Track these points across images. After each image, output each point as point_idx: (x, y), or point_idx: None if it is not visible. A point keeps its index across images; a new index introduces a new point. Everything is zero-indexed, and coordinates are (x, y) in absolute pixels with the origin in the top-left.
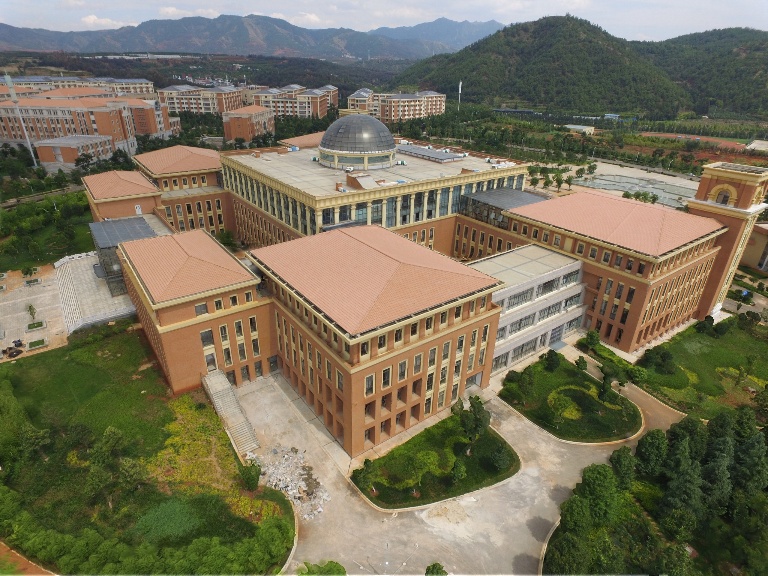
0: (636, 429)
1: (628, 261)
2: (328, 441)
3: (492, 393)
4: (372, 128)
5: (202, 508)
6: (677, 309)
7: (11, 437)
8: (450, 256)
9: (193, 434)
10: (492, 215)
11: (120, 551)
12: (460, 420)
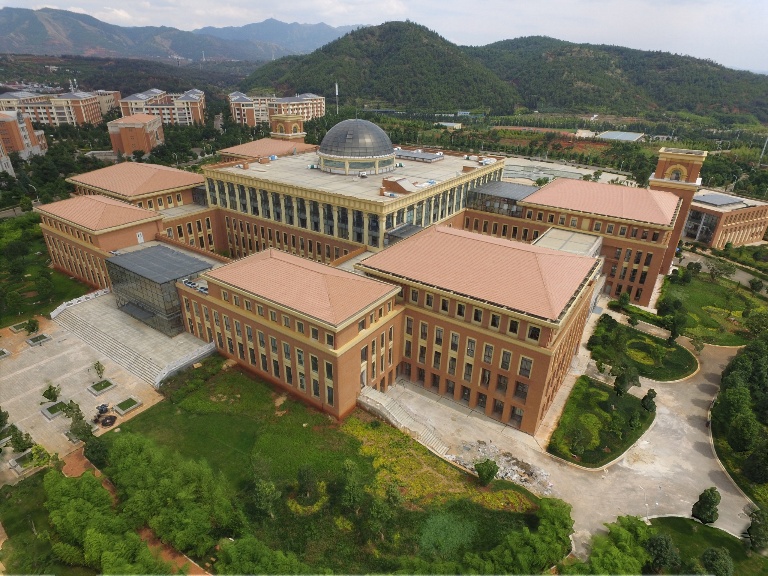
0: (696, 362)
1: (643, 232)
2: (501, 427)
3: (586, 358)
4: (377, 132)
5: (464, 512)
6: None
7: (227, 503)
8: None
9: (392, 451)
10: (505, 206)
11: (454, 568)
12: (586, 384)
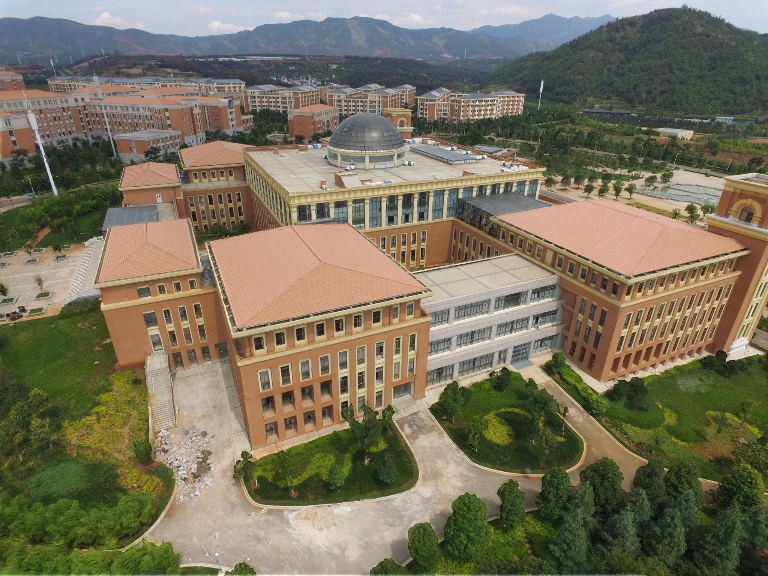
0: (569, 465)
1: (603, 279)
2: (239, 430)
3: (424, 405)
4: (376, 127)
5: (93, 473)
6: (678, 339)
7: None
8: (444, 261)
9: (119, 406)
10: (483, 221)
11: None
12: None
